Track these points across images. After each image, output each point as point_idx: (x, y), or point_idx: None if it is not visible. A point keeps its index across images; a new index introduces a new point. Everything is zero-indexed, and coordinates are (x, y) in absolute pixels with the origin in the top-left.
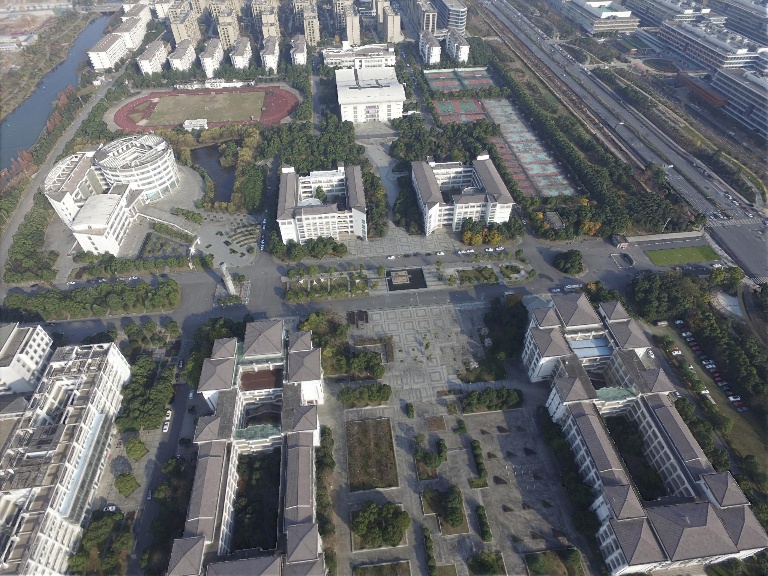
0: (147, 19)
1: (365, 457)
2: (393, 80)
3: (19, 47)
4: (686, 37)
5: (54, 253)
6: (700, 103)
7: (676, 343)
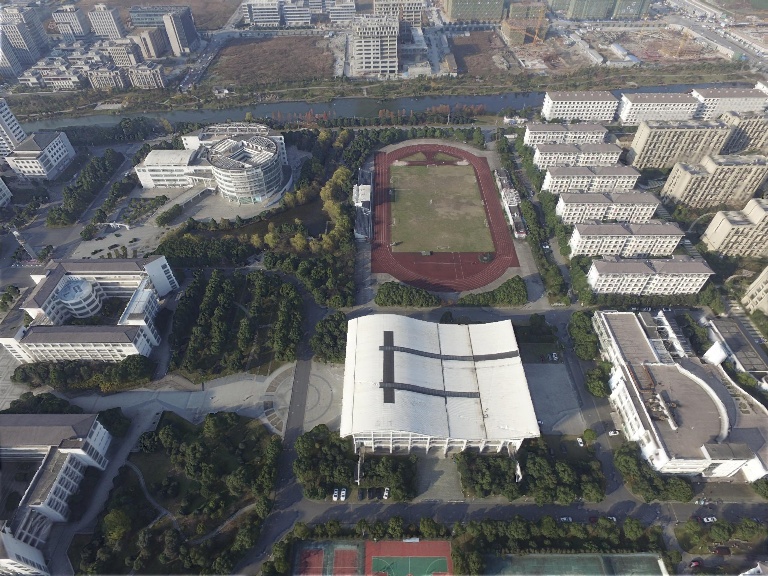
0: (739, 111)
1: None
2: (474, 429)
3: (600, 63)
4: None
5: None
6: None
7: None
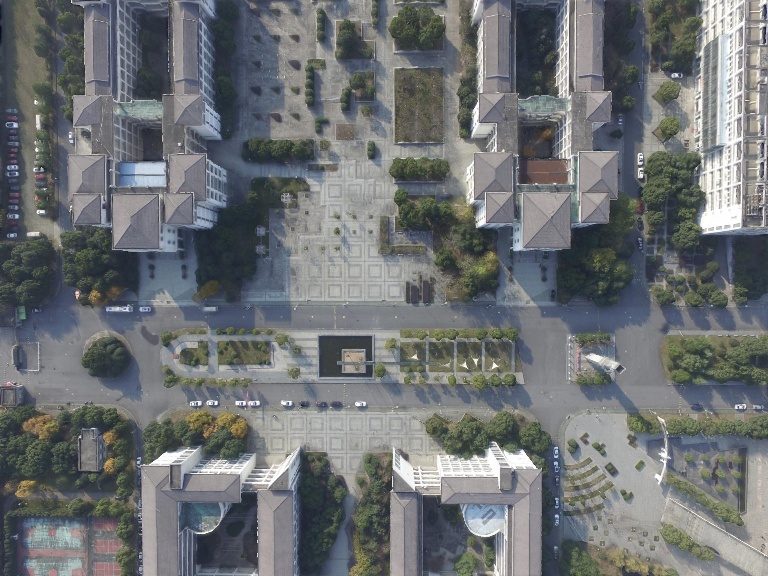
0: None
1: (426, 101)
2: None
3: None
4: None
5: None
6: None
7: (33, 206)
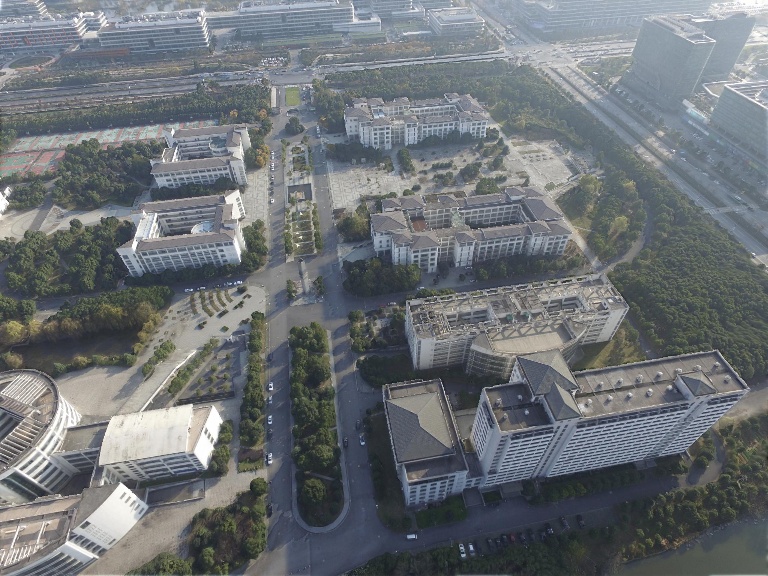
0: None
1: None
2: None
3: None
4: (15, 33)
5: (201, 511)
6: (117, 59)
7: None
